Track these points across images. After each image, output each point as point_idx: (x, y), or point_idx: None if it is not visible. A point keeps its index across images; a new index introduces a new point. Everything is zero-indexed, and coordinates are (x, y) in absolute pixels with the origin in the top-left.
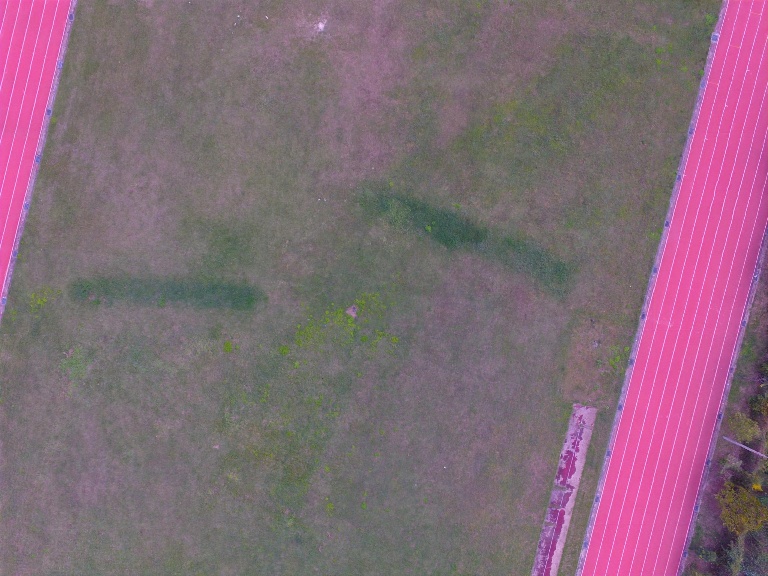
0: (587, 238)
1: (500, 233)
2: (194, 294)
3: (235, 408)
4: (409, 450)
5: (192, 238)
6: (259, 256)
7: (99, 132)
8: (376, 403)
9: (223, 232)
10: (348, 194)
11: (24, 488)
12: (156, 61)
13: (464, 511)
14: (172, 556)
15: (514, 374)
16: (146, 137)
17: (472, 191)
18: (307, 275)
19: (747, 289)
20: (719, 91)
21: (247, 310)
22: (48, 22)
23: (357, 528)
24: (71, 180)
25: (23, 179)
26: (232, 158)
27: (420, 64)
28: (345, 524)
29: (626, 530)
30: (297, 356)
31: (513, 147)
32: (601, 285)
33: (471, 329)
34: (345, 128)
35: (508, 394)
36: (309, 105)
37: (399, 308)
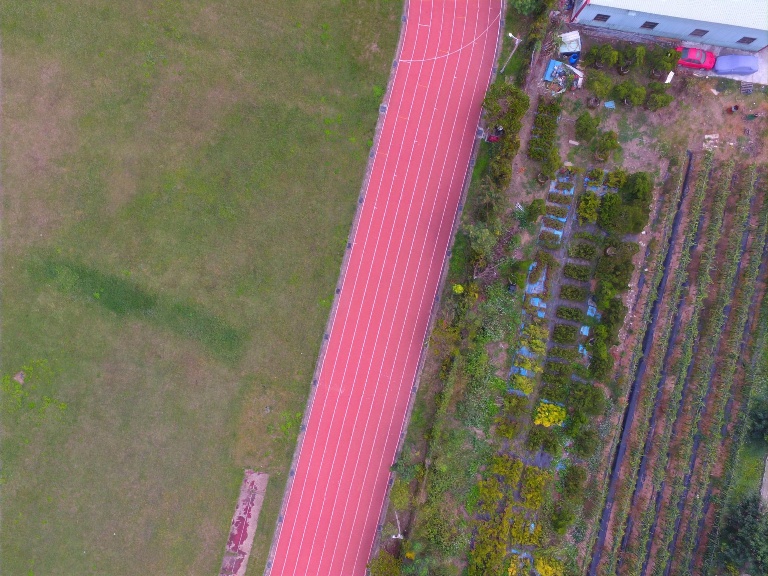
0: (258, 305)
1: (170, 300)
2: None
3: None
4: (78, 517)
5: None
6: None
7: None
8: (44, 470)
9: None
10: (16, 261)
11: None
12: None
13: None
14: None
15: (185, 440)
16: None
17: (142, 258)
18: None
19: (417, 356)
20: (388, 161)
21: None
22: None
23: None
24: None
25: None
26: None
27: (89, 132)
28: None
29: None
30: None
31: (183, 215)
32: (272, 351)
33: (141, 395)
34: (13, 195)
35: (179, 460)
36: None
37: (68, 374)
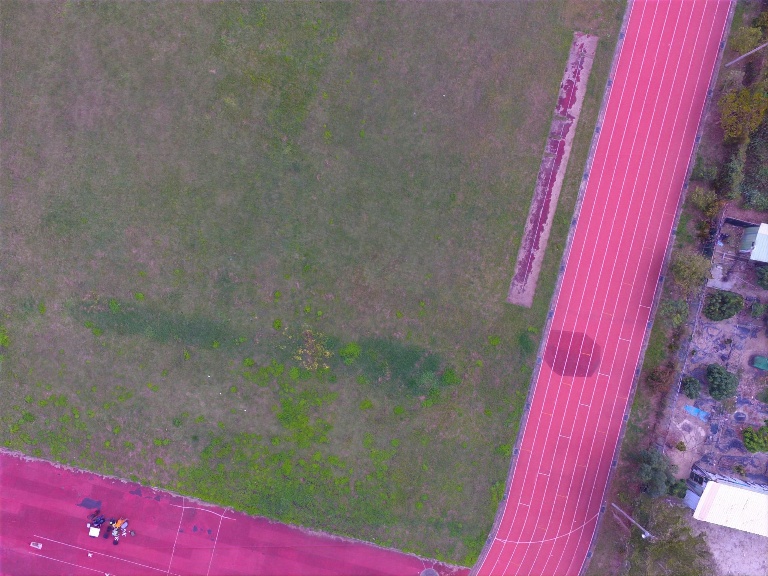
0: None
1: None
2: None
3: (232, 31)
4: (408, 77)
5: None
6: None
7: None
8: (375, 29)
9: None
10: None
11: (19, 110)
12: None
13: (463, 140)
14: (169, 181)
15: (514, 1)
16: None
17: None
18: None
19: None
20: None
21: None
22: None
23: (355, 156)
24: None
25: None
26: None
27: None
28: (343, 152)
29: (627, 161)
30: None
31: None
32: None
33: None
34: None
35: (508, 21)
36: None
37: None
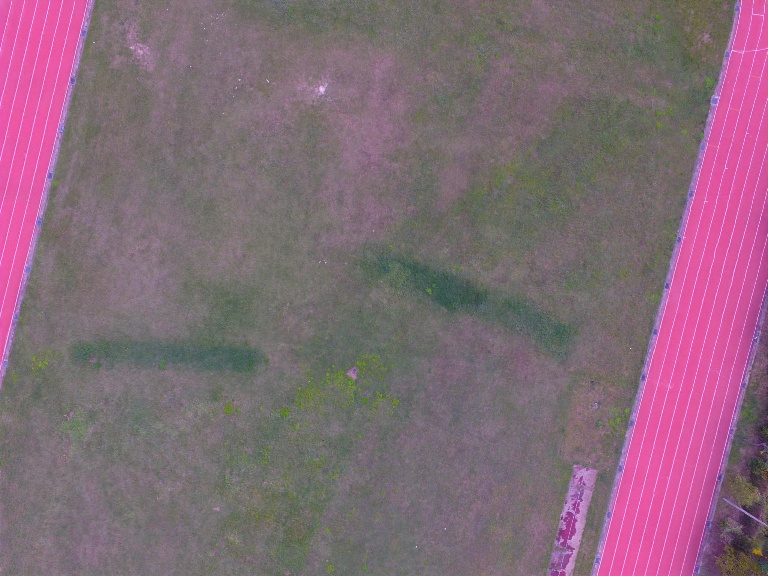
0: (587, 300)
1: (500, 295)
2: (195, 356)
3: (236, 470)
4: (409, 512)
5: (193, 301)
6: (260, 318)
7: (100, 195)
8: (376, 465)
9: (224, 295)
10: (349, 257)
11: (25, 550)
12: (157, 125)
13: (464, 572)
14: None
15: (514, 436)
16: (147, 200)
17: (472, 253)
18: (308, 337)
19: (747, 351)
20: (719, 154)
21: (248, 372)
22: (50, 86)
23: None
24: (72, 243)
25: (24, 242)
26: (233, 221)
27: (420, 127)
28: None
29: None
30: (298, 418)
31: (513, 209)
32: (601, 347)
33: (471, 391)
34: (346, 191)
35: (508, 455)
36: (310, 168)
37: (399, 370)
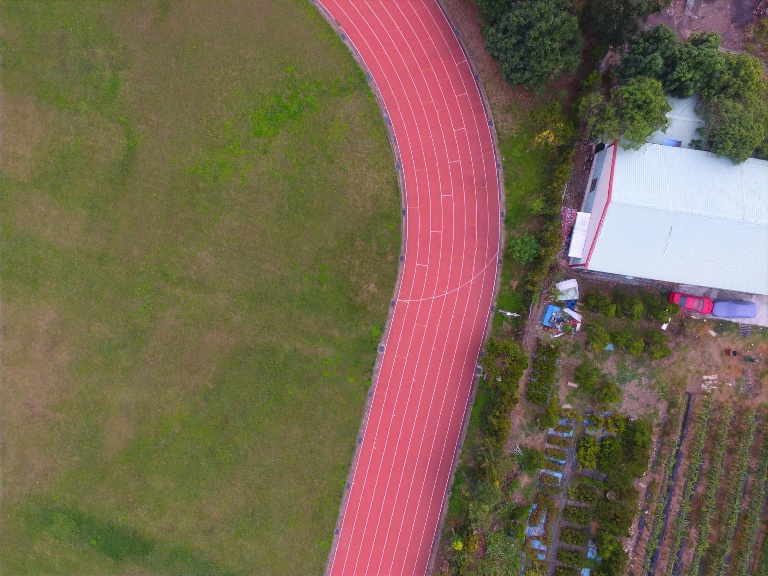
0: (256, 548)
1: (168, 545)
2: None
3: None
4: None
5: None
6: None
7: None
8: None
9: None
10: (12, 509)
11: None
12: None
13: None
14: None
15: None
16: None
17: (139, 503)
18: None
19: None
20: (386, 401)
21: None
22: None
23: None
24: None
25: None
26: None
27: (85, 378)
28: None
29: None
30: None
31: (181, 459)
32: None
33: None
34: (9, 443)
35: None
36: None
37: None
